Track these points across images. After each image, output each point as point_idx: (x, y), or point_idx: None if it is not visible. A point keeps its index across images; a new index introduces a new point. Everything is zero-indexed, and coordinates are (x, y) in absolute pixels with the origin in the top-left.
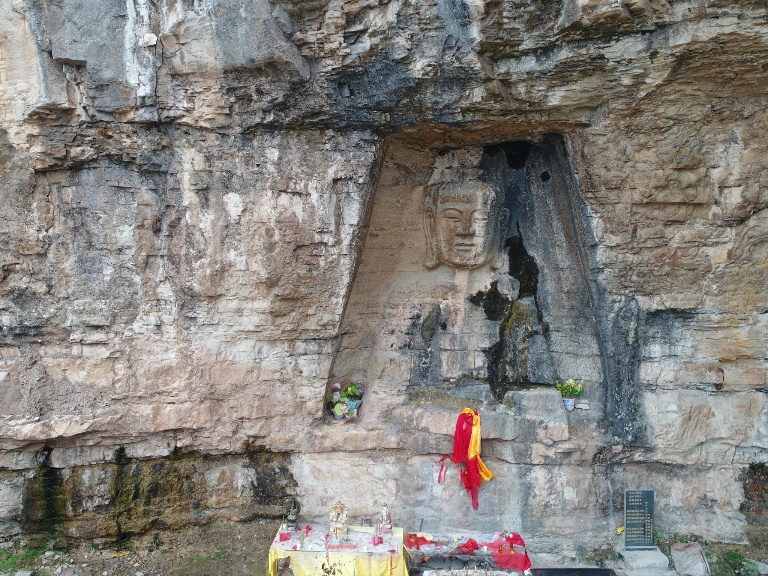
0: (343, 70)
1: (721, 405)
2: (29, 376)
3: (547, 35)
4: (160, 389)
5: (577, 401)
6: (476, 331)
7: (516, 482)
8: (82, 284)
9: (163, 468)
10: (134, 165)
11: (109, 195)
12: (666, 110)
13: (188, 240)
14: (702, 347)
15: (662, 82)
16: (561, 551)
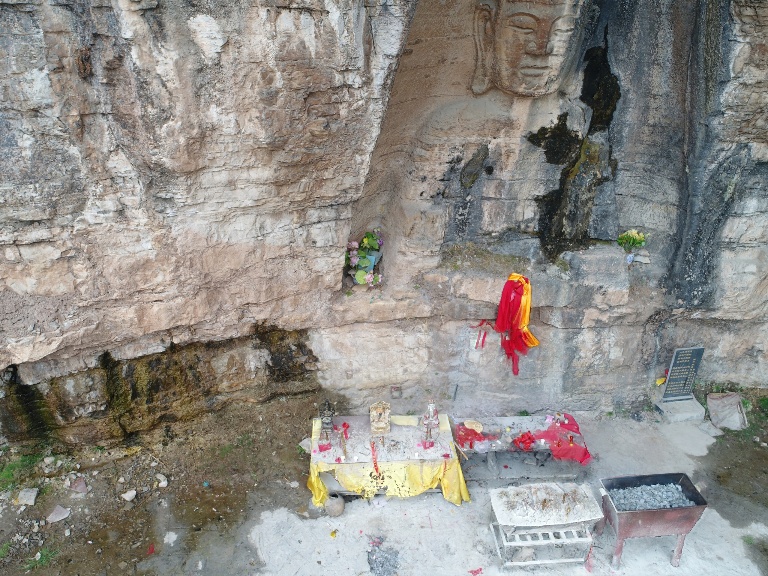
0: None
1: None
2: None
3: None
4: (140, 287)
5: None
6: (530, 176)
7: (562, 347)
8: None
9: (160, 363)
10: None
11: None
12: None
13: (142, 94)
14: None
15: None
16: (599, 407)
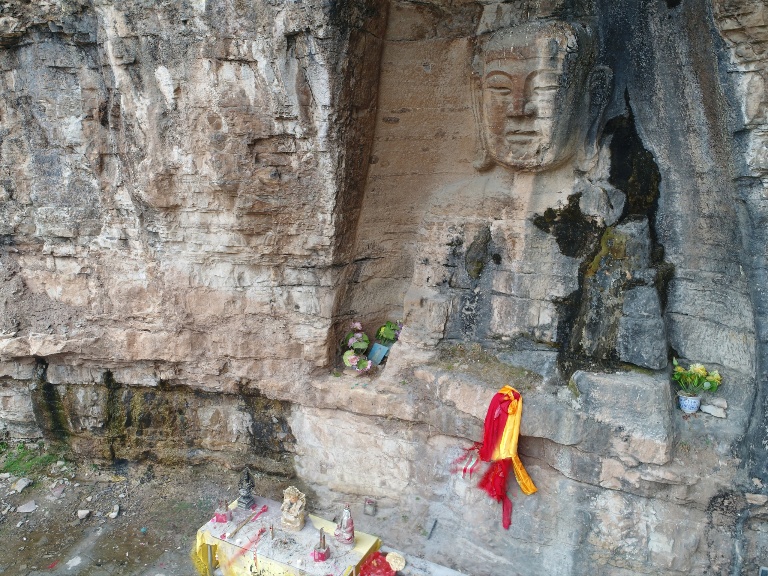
0: None
1: None
2: (6, 288)
3: None
4: (133, 313)
5: (709, 399)
6: (544, 270)
7: (571, 507)
8: (43, 188)
9: (154, 398)
10: (69, 37)
11: (47, 79)
12: None
13: (127, 134)
14: None
15: None
16: None
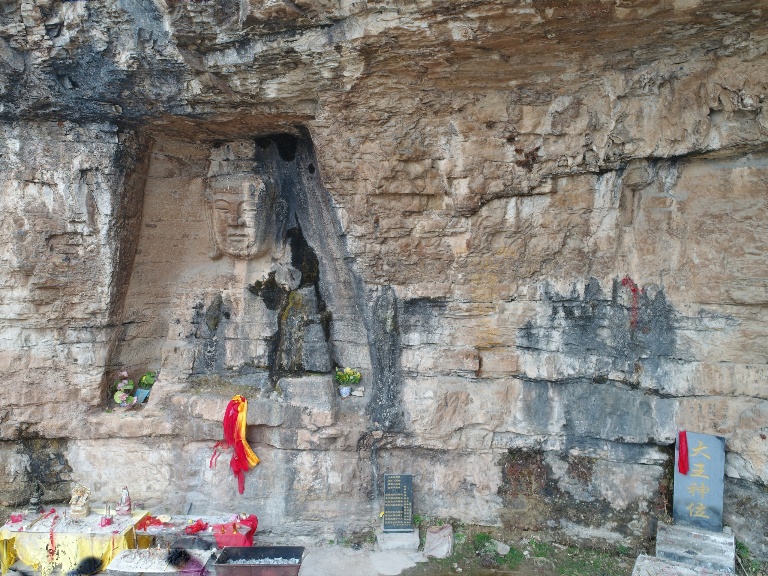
0: (53, 62)
1: (482, 392)
2: None
3: (236, 29)
4: None
5: (356, 389)
6: (257, 320)
7: (282, 467)
8: None
9: None
10: None
11: None
12: (378, 103)
13: None
14: (460, 335)
15: (361, 75)
16: (321, 534)
